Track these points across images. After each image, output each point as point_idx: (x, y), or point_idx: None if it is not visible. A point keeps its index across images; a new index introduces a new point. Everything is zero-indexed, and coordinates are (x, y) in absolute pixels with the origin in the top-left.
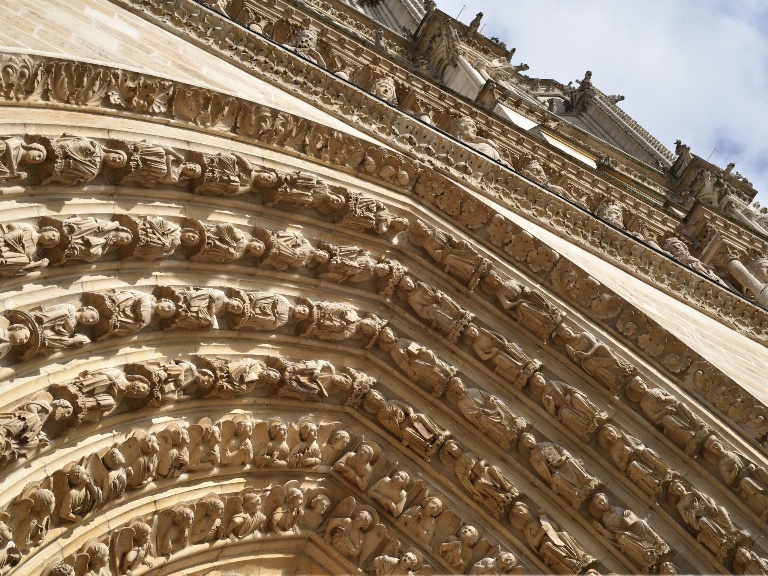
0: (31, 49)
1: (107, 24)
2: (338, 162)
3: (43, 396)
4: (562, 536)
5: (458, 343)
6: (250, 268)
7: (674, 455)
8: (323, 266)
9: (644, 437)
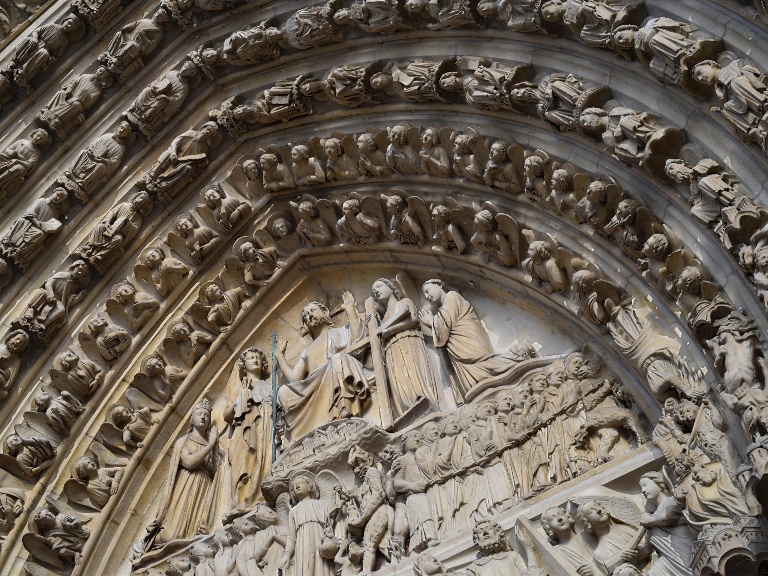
0: None
1: None
2: None
3: None
4: (408, 73)
5: None
6: (58, 151)
7: None
8: (115, 75)
9: None
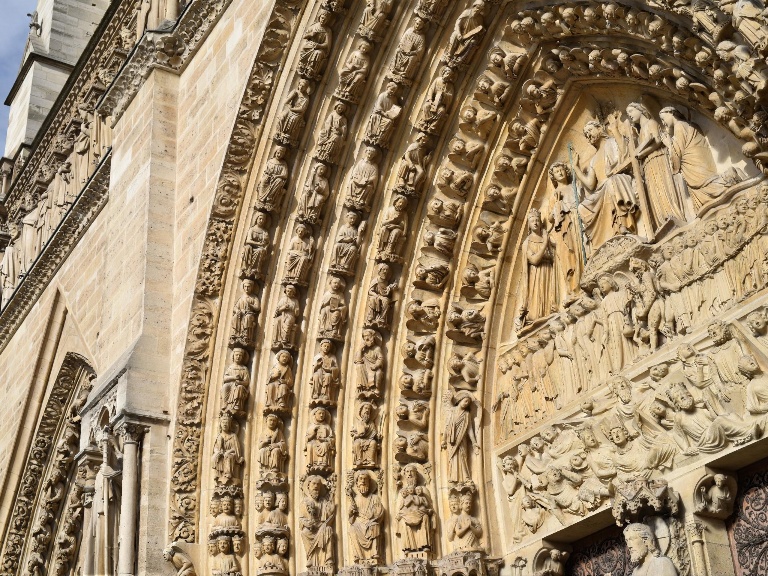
0: None
1: None
2: None
3: (376, 271)
4: None
5: None
6: (380, 51)
7: None
8: None
9: None
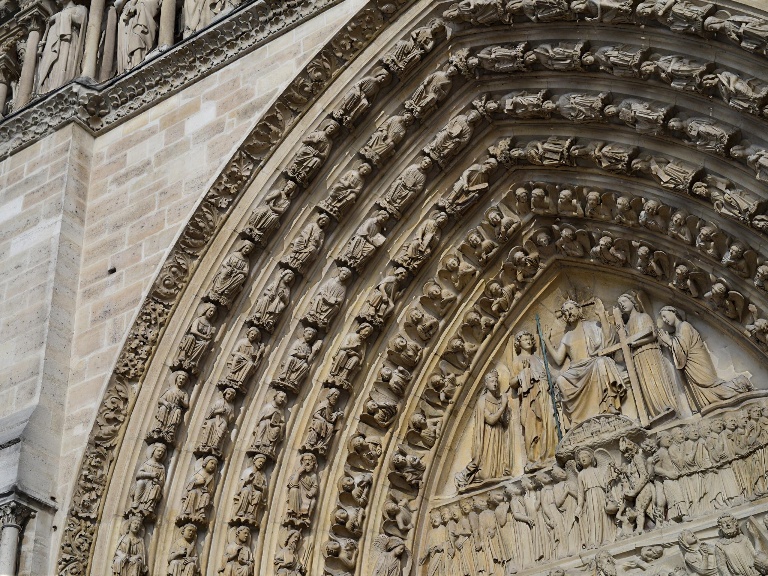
0: (167, 250)
1: (198, 128)
2: (370, 36)
3: (323, 395)
4: (666, 172)
5: (535, 67)
6: (376, 177)
7: (702, 44)
8: None
9: (676, 46)
